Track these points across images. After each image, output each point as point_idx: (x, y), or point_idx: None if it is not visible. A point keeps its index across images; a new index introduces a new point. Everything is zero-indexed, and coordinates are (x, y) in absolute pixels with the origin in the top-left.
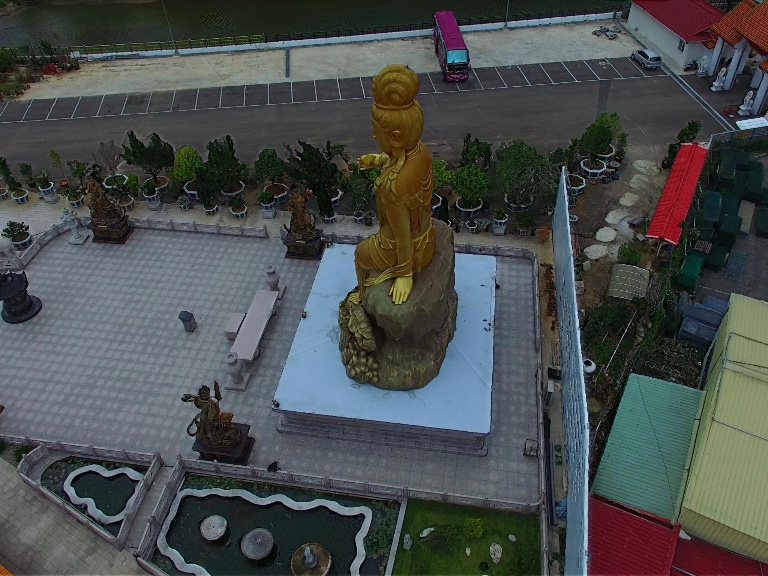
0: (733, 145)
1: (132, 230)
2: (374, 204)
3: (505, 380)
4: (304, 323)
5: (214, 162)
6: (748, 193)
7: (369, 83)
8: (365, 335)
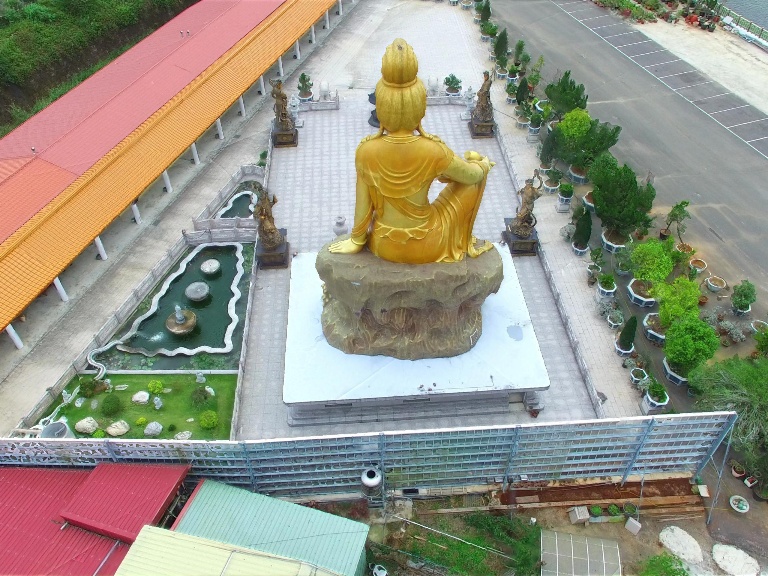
0: None
1: (491, 136)
2: None
3: None
4: None
5: None
6: None
7: None
8: None
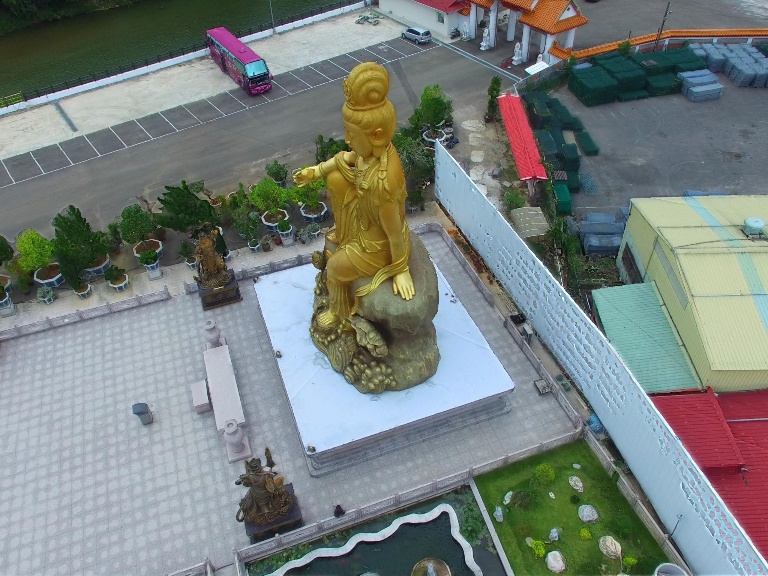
0: (529, 89)
1: None
2: (259, 229)
3: None
4: (283, 362)
5: (67, 239)
6: (565, 124)
7: (172, 116)
8: (377, 344)
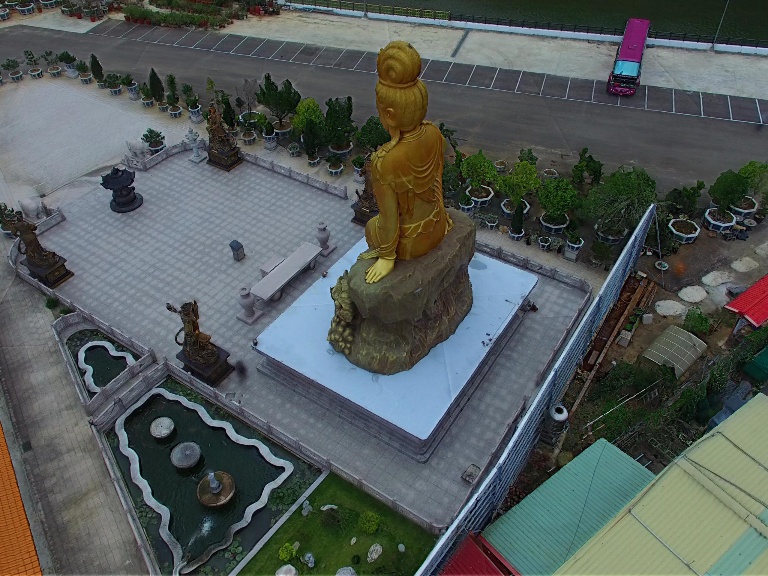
0: None
1: (241, 161)
2: None
3: (487, 401)
4: (321, 281)
5: (329, 118)
6: None
7: (528, 78)
8: (343, 305)
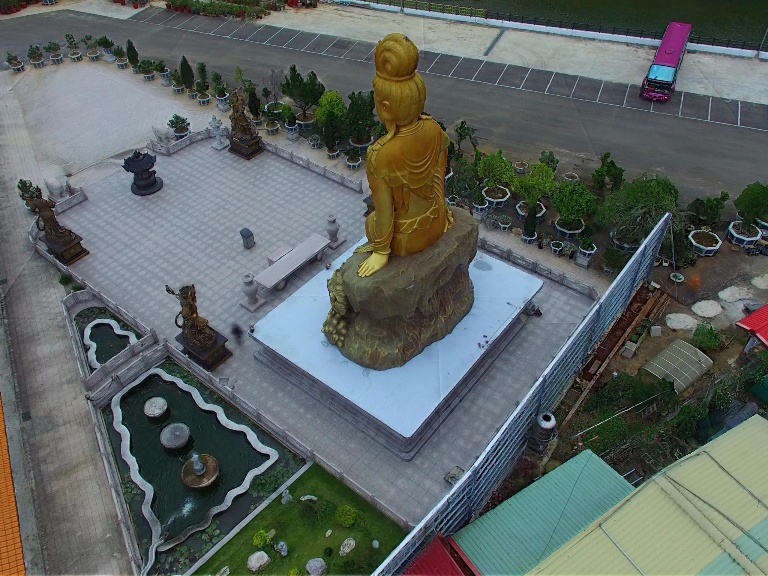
0: None
1: (262, 151)
2: None
3: (479, 403)
4: (324, 273)
5: (351, 111)
6: None
7: (560, 80)
8: (338, 297)
